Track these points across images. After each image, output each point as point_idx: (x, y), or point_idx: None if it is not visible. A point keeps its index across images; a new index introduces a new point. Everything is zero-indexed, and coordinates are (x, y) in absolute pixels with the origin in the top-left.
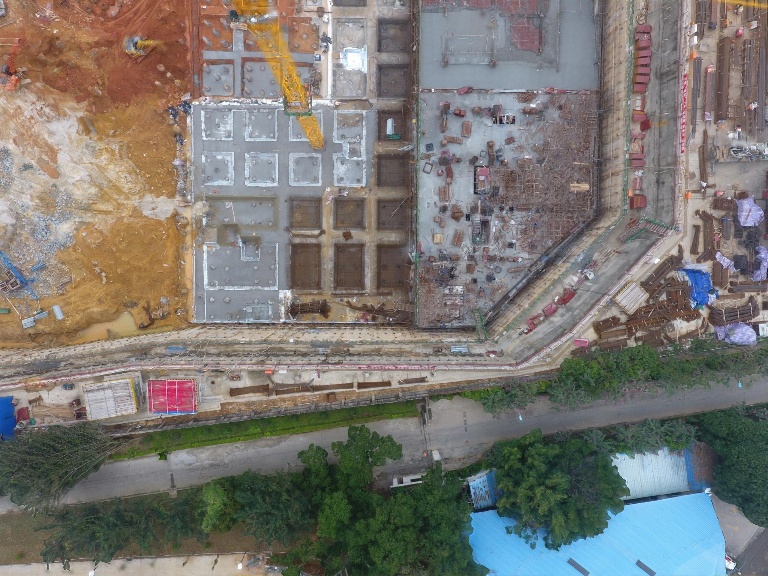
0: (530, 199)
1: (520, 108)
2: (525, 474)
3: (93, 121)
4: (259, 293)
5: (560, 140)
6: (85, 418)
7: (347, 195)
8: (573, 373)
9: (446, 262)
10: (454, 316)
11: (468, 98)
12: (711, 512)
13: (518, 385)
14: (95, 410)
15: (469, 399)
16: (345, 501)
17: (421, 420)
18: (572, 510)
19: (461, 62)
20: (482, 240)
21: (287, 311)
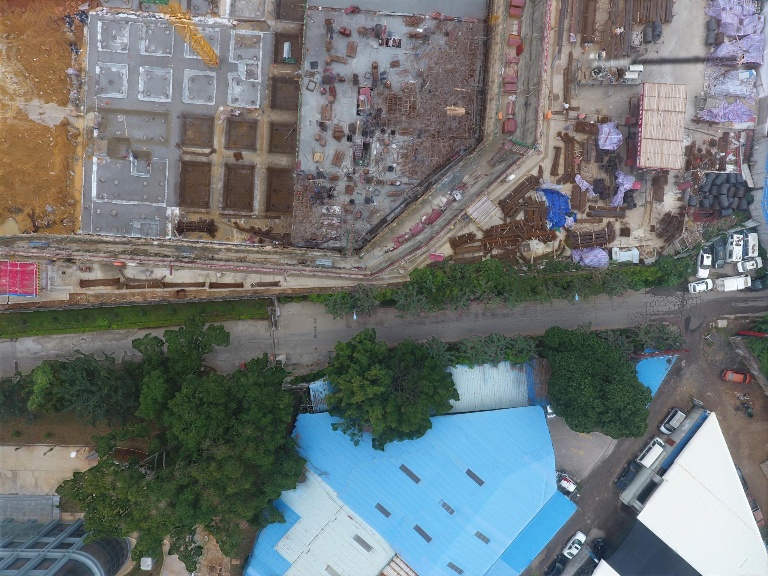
0: (412, 124)
1: (407, 32)
2: None
3: None
4: (147, 208)
5: (445, 66)
6: None
7: (240, 115)
8: (418, 281)
9: (323, 180)
10: (330, 236)
11: (355, 18)
12: (543, 425)
13: (363, 290)
14: None
15: (320, 306)
16: (161, 380)
17: (271, 324)
18: (390, 404)
19: None
20: (365, 164)
21: (174, 228)
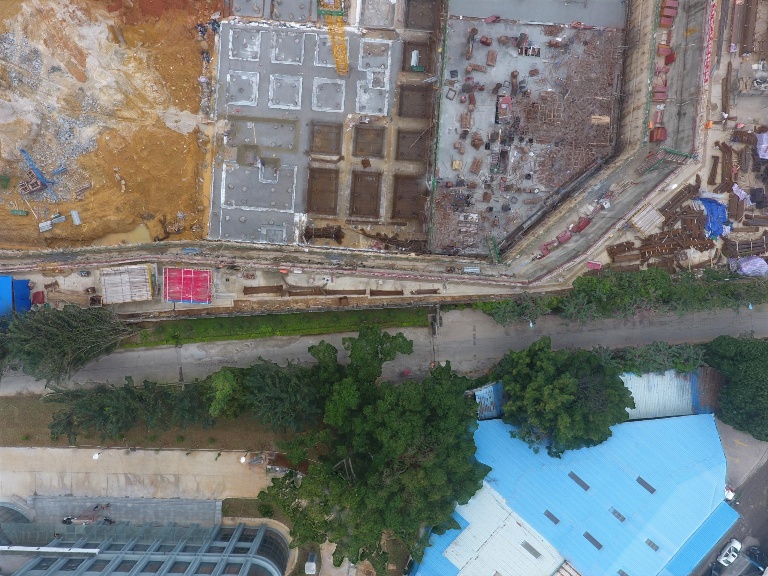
0: (550, 132)
1: (546, 41)
2: (533, 377)
3: (123, 30)
4: (275, 215)
5: None
6: (99, 305)
7: (368, 123)
8: (585, 289)
9: (463, 188)
10: (467, 243)
11: (495, 28)
12: (714, 433)
13: (530, 298)
14: (110, 294)
15: (480, 313)
16: (354, 387)
17: (431, 331)
18: (578, 412)
19: None
20: (500, 171)
21: (301, 234)
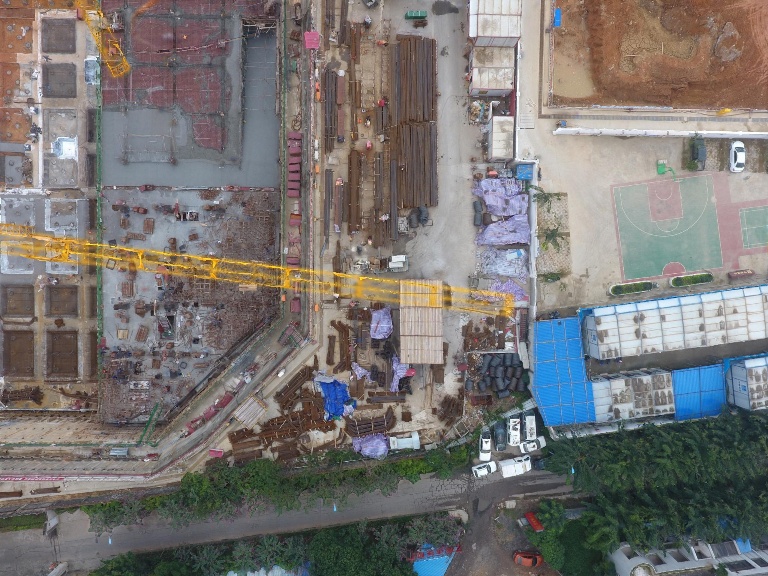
0: (215, 295)
1: (203, 205)
2: None
3: None
4: None
5: (242, 237)
6: None
7: (59, 283)
8: (185, 490)
9: (125, 359)
10: (139, 411)
11: (151, 195)
12: None
13: None
14: None
15: None
16: None
17: None
18: None
19: (141, 160)
20: None
21: None
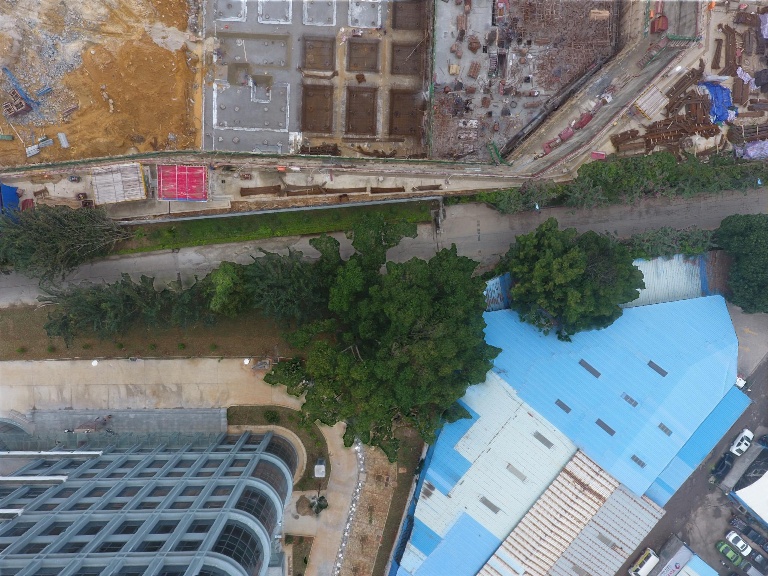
0: (548, 33)
1: None
2: (541, 256)
3: None
4: (269, 134)
5: None
6: None
7: (361, 36)
8: (590, 174)
9: (462, 92)
10: (468, 151)
11: None
12: (725, 314)
13: (534, 185)
14: (103, 194)
15: (483, 208)
16: (359, 268)
17: (434, 227)
18: (588, 287)
19: None
20: (498, 77)
21: None
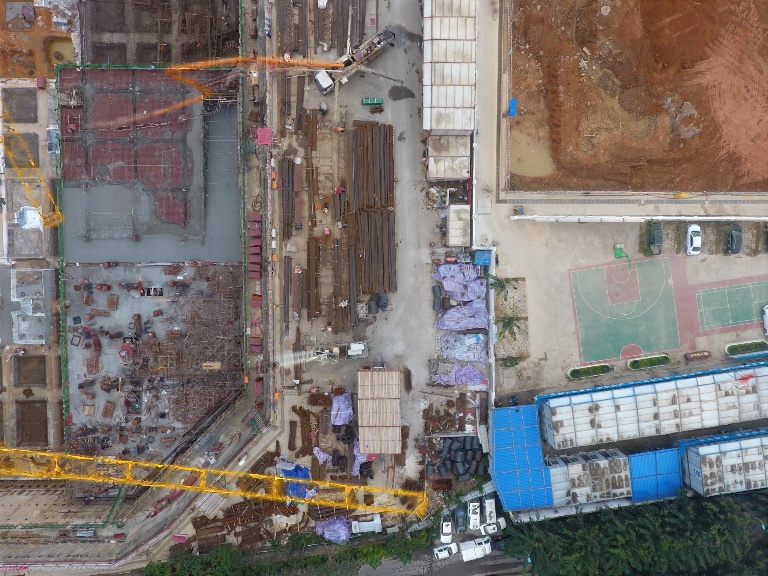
0: (180, 370)
1: (167, 280)
2: None
3: None
4: None
5: None
6: None
7: (26, 353)
8: None
9: (92, 436)
10: (108, 486)
11: (114, 271)
12: None
13: None
14: None
15: None
16: None
17: None
18: None
19: (104, 237)
20: None
21: None
